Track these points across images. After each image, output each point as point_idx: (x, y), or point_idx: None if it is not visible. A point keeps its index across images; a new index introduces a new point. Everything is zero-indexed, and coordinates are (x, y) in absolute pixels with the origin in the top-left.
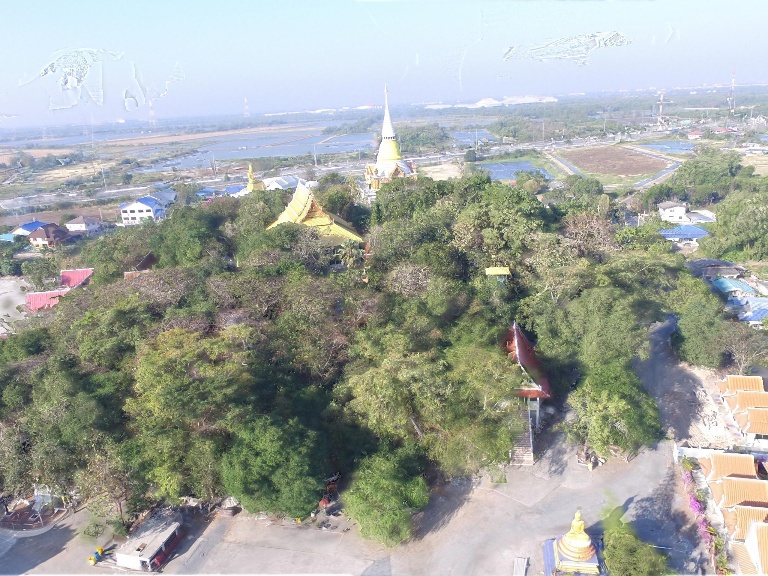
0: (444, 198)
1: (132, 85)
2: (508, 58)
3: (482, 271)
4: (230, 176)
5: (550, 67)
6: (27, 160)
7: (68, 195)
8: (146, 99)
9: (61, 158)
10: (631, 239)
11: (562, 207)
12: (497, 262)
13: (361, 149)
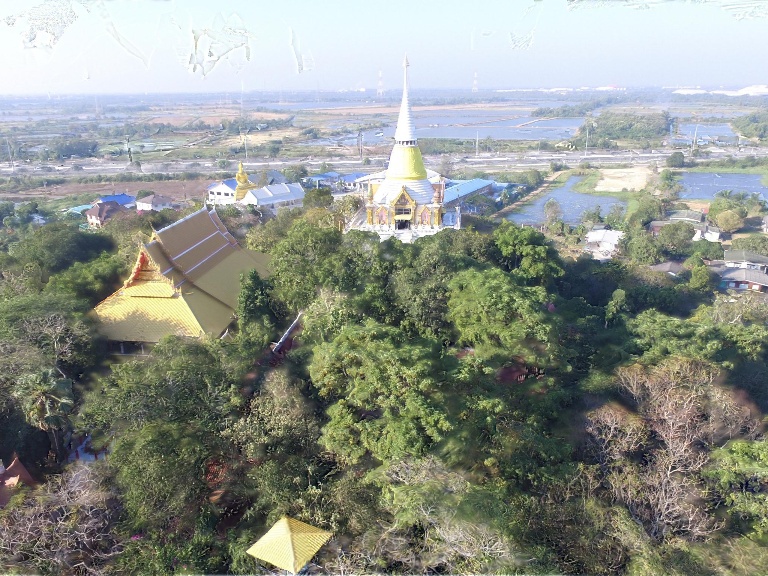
0: (396, 274)
1: (288, 52)
2: (579, 2)
3: (269, 523)
4: (371, 159)
5: (666, 22)
6: (228, 123)
7: (204, 165)
8: (301, 68)
9: (262, 123)
10: (762, 485)
11: (641, 331)
12: (316, 506)
13: (542, 138)
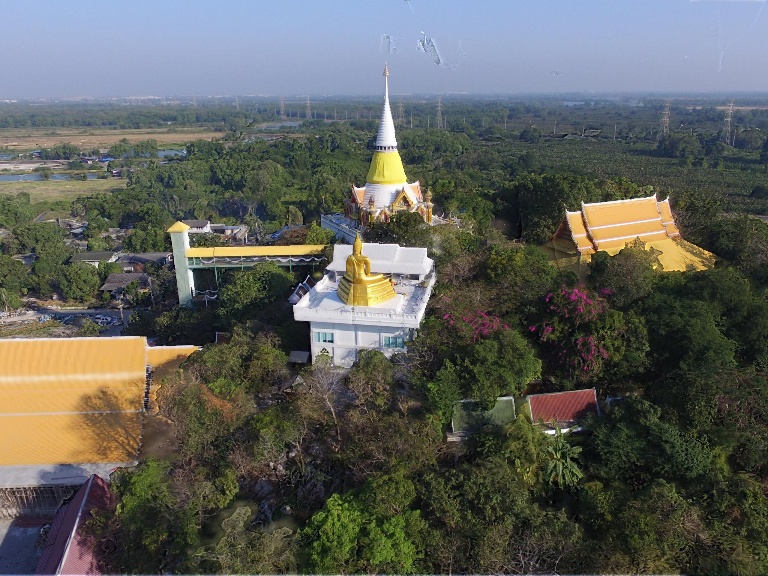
0: None
1: None
2: None
3: None
4: None
5: None
6: None
7: None
8: None
9: None
10: None
11: None
12: None
13: None
